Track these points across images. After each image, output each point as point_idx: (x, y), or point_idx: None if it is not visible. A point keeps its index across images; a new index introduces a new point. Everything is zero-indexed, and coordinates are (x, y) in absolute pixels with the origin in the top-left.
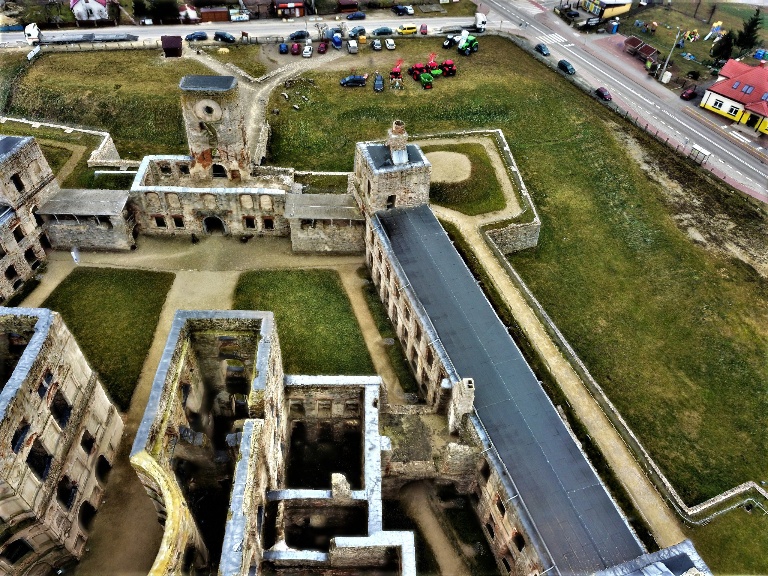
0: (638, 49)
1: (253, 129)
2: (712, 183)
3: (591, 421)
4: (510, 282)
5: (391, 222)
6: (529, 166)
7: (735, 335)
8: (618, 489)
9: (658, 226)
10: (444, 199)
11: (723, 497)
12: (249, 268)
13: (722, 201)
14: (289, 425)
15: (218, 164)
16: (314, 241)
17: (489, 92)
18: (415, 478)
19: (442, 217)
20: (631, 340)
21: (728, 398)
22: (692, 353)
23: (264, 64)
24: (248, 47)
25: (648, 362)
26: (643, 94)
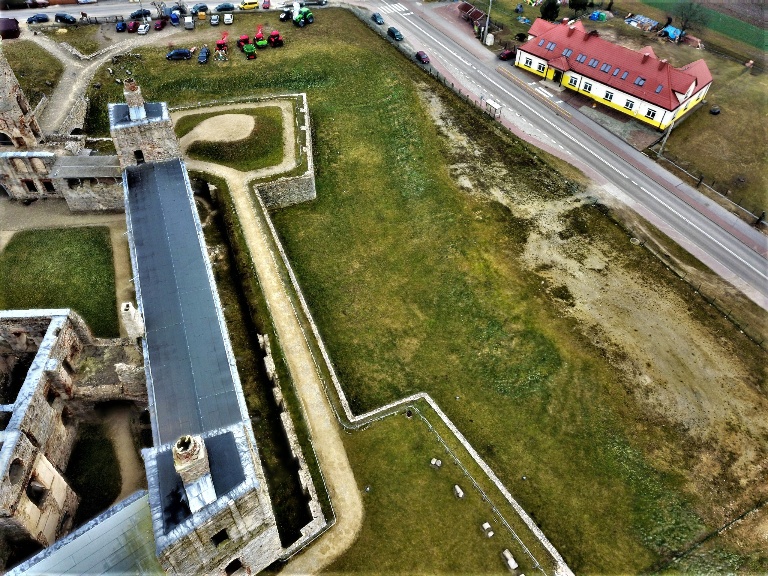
0: (469, 14)
1: (70, 103)
2: (499, 135)
3: (291, 346)
4: (260, 229)
5: (136, 176)
6: (333, 127)
7: (471, 270)
8: (294, 403)
9: (431, 175)
10: (221, 157)
11: (389, 406)
12: (24, 228)
13: (502, 151)
14: (4, 361)
15: (0, 132)
16: (87, 200)
17: (311, 60)
18: (101, 400)
19: (214, 174)
20: (377, 279)
21: (449, 326)
22: (429, 288)
23: (98, 42)
24: (87, 27)
25: (386, 298)
26: (464, 56)
